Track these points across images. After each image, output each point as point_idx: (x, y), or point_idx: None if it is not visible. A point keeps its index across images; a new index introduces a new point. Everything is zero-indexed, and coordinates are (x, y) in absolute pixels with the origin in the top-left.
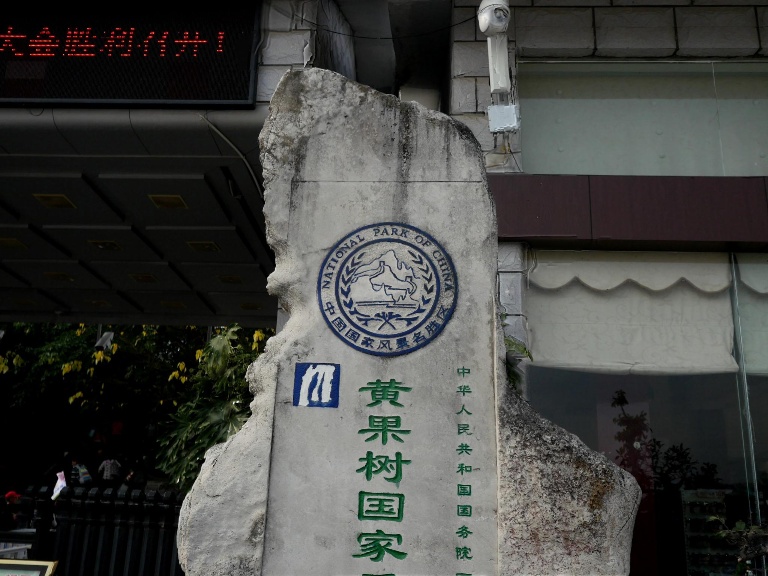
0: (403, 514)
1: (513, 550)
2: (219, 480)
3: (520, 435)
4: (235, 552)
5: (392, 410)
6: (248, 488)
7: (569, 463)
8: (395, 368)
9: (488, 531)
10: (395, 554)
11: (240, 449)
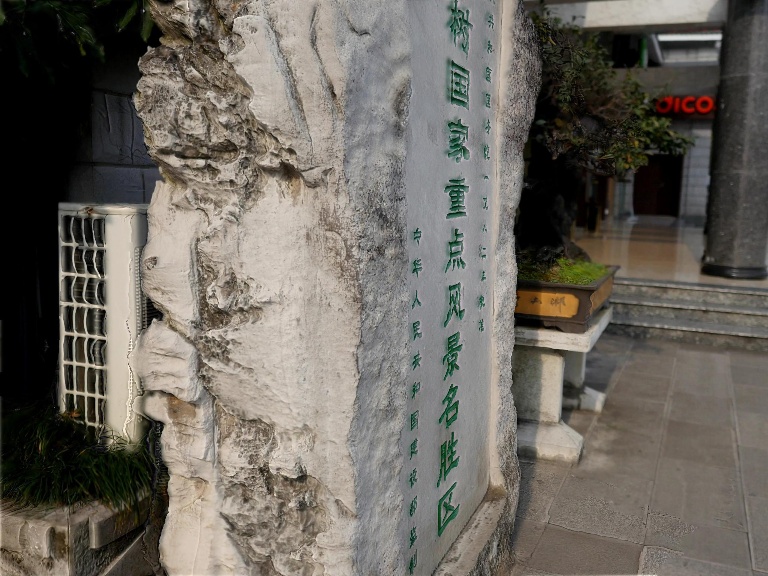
0: (469, 100)
1: None
2: (363, 2)
3: (524, 16)
4: (388, 146)
5: None
6: (395, 28)
7: (538, 57)
8: None
9: None
10: None
11: None
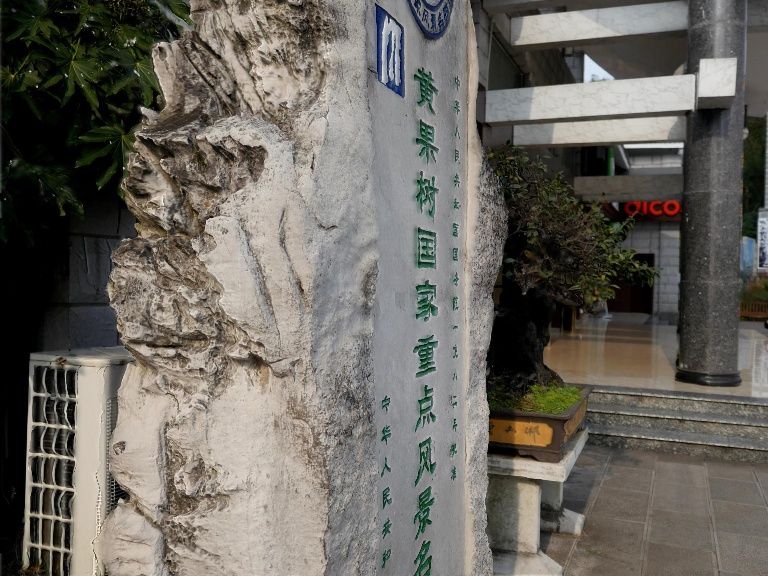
0: (436, 259)
1: (474, 296)
2: (330, 197)
3: None
4: (355, 327)
5: (430, 117)
6: (361, 216)
7: None
8: (431, 57)
9: (462, 277)
10: (431, 310)
11: (345, 142)
